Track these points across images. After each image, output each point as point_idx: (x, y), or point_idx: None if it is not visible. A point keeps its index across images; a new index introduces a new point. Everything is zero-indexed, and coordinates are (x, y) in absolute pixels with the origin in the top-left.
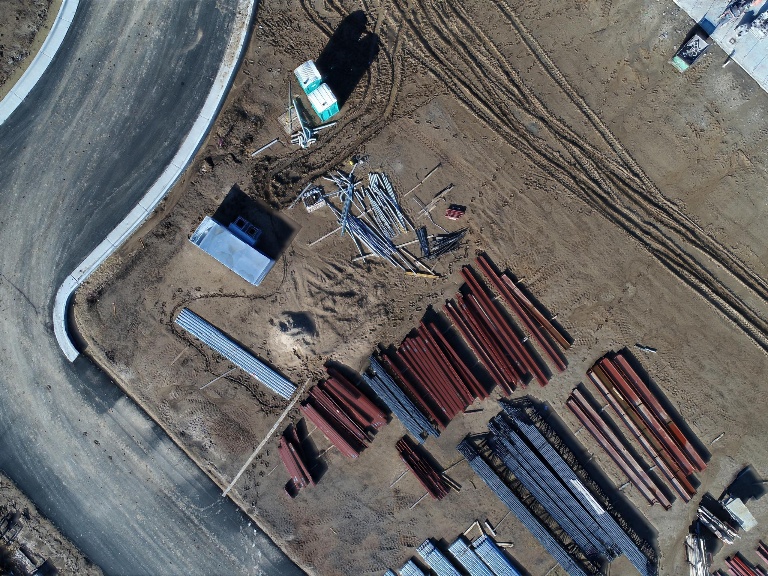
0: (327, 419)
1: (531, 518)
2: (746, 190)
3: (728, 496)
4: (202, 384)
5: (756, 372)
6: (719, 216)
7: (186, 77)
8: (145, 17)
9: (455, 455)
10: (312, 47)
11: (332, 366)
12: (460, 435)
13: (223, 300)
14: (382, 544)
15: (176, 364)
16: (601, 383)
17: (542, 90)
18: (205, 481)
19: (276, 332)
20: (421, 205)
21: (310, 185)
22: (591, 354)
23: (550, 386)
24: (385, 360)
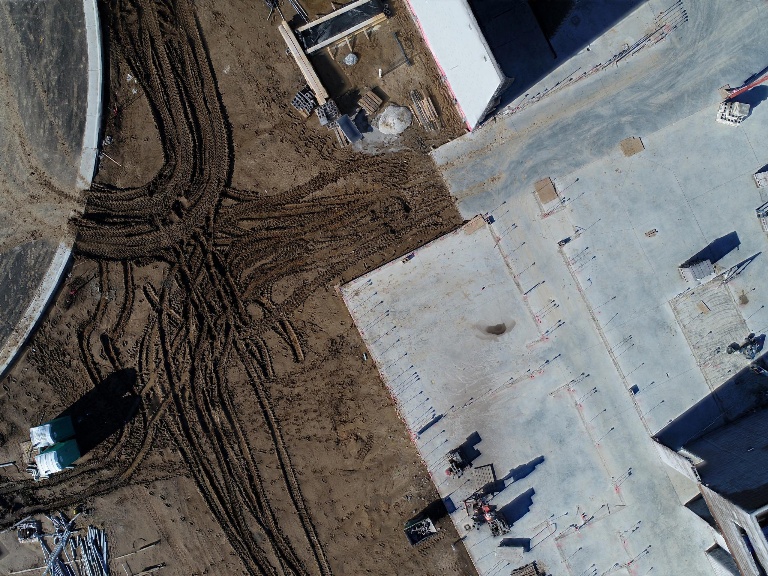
0: None
1: None
2: None
3: None
4: None
5: None
6: None
7: None
8: None
9: None
10: (76, 387)
11: None
12: None
13: None
14: None
15: None
16: None
17: (279, 505)
18: None
19: None
20: (128, 573)
21: (30, 517)
22: None
23: None
24: None
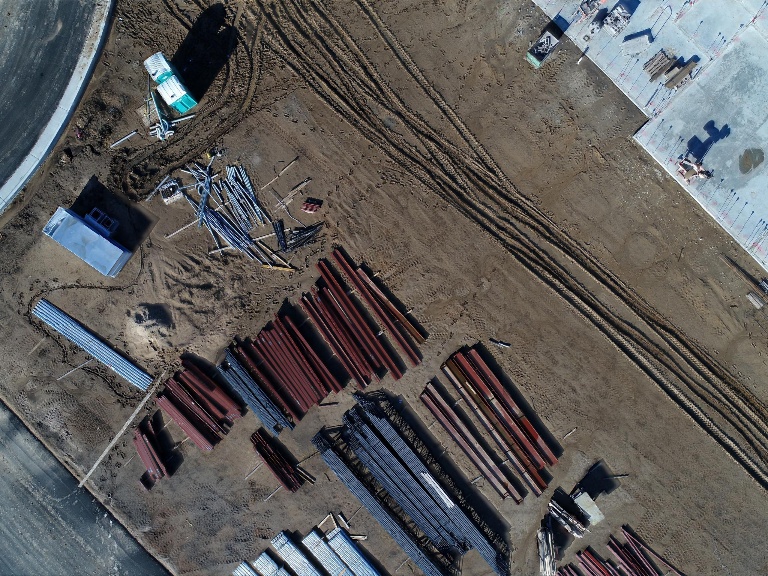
0: (182, 411)
1: (381, 511)
2: (600, 187)
3: (579, 490)
4: (59, 375)
5: (608, 368)
6: (573, 212)
7: (45, 68)
8: (5, 7)
9: (310, 448)
10: (171, 39)
11: (188, 358)
12: (315, 428)
13: (80, 291)
14: (237, 536)
15: (34, 355)
16: (454, 377)
17: (399, 85)
18: (62, 472)
19: (132, 324)
20: (278, 198)
21: (168, 177)
22: (446, 348)
23: (404, 380)
24: (241, 352)
